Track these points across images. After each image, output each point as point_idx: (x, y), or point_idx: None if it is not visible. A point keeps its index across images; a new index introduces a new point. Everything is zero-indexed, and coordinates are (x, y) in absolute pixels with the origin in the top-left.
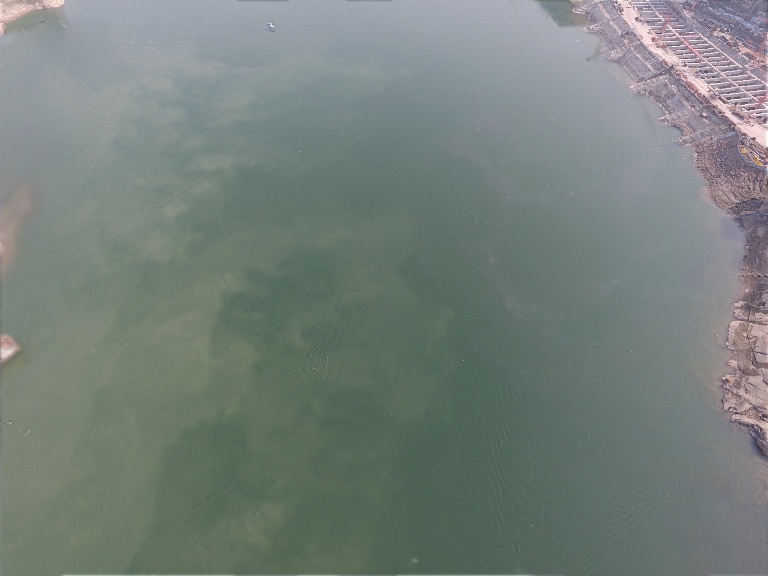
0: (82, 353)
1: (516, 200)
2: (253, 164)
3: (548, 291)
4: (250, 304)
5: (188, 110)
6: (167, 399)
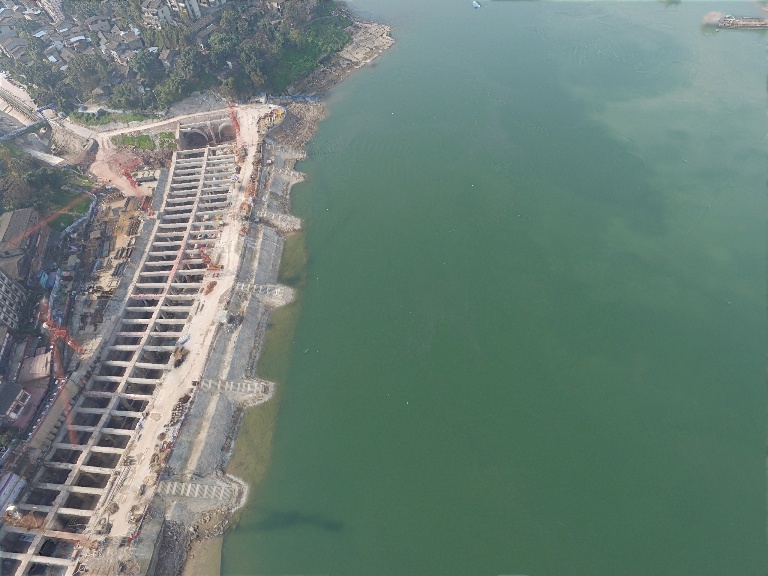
0: (717, 53)
1: (470, 111)
2: None
3: (460, 69)
4: None
5: None
6: (647, 31)
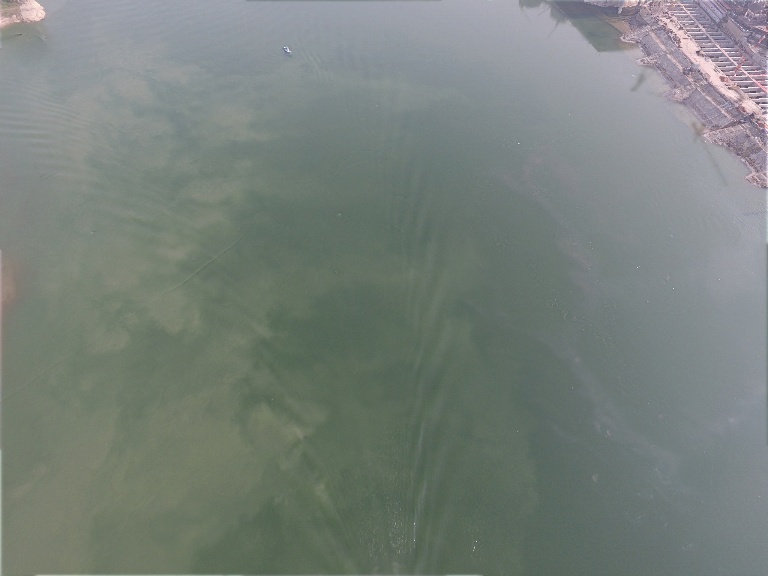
0: (93, 512)
1: (606, 286)
2: (287, 234)
3: (670, 418)
4: (302, 433)
5: (200, 156)
6: None
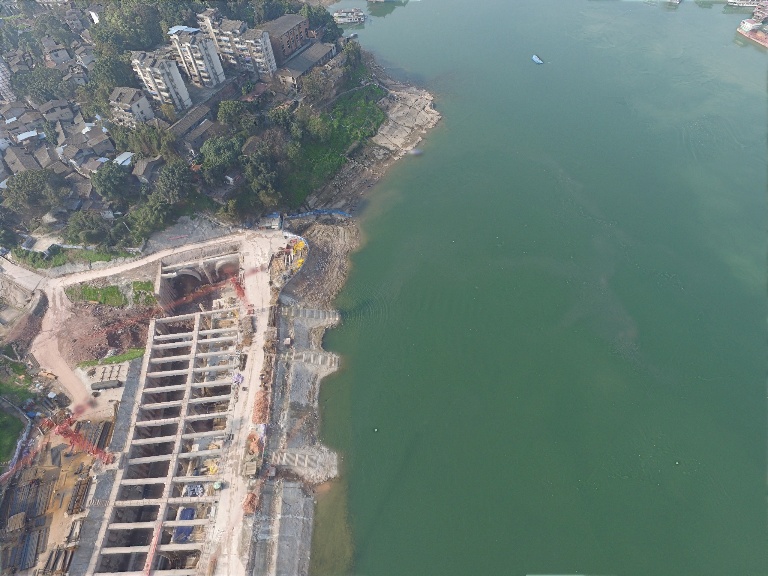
0: None
1: (560, 239)
2: None
3: (534, 163)
4: None
5: None
6: None
